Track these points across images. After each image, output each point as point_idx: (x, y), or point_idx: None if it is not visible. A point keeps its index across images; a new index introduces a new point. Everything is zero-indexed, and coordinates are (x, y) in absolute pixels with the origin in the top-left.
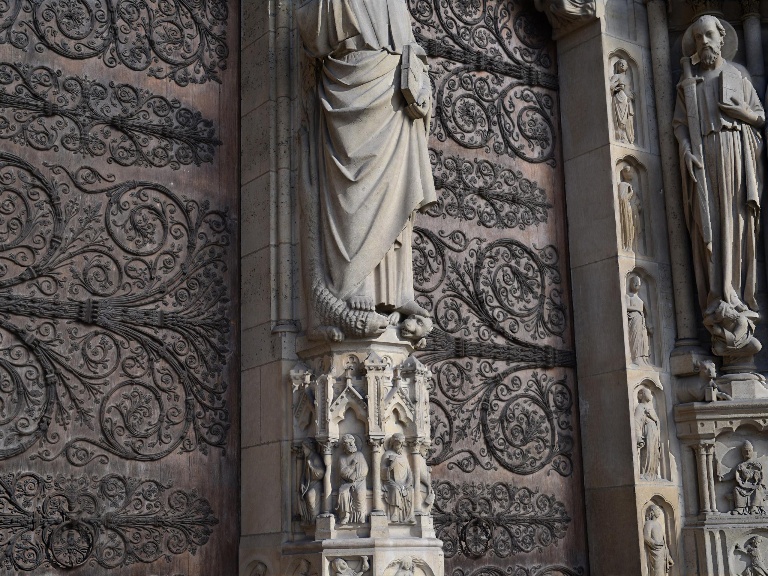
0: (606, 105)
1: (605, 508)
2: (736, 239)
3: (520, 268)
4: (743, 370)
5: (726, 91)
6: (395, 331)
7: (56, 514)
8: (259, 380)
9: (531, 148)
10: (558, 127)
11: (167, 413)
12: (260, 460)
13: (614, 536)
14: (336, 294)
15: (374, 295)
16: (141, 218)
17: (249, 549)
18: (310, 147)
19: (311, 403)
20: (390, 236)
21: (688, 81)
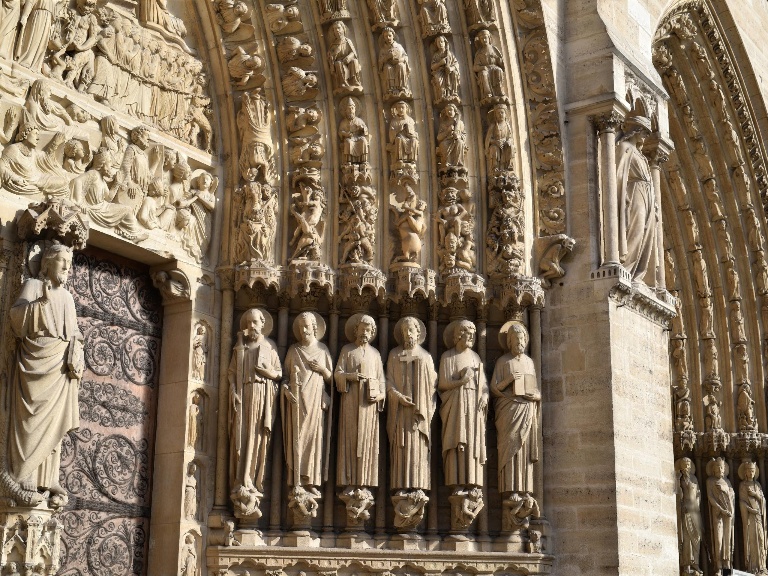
0: (189, 356)
1: None
2: (255, 449)
3: (123, 453)
4: (250, 528)
5: (260, 358)
6: (46, 503)
7: None
8: None
9: (139, 375)
10: (158, 362)
11: None
12: None
13: None
14: (15, 479)
15: (37, 481)
16: None
17: None
18: (8, 388)
19: None
20: (50, 447)
21: (240, 347)
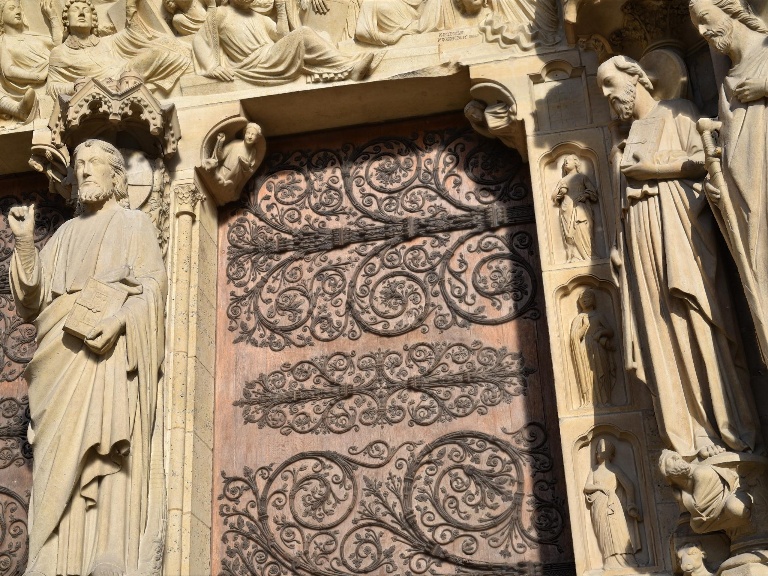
0: (536, 224)
1: None
2: (678, 351)
3: (480, 465)
4: (744, 549)
5: (629, 148)
6: None
7: None
8: None
9: (496, 306)
10: None
11: None
12: None
13: None
14: None
15: (56, 567)
16: None
17: None
18: None
19: None
20: (65, 495)
21: (611, 152)
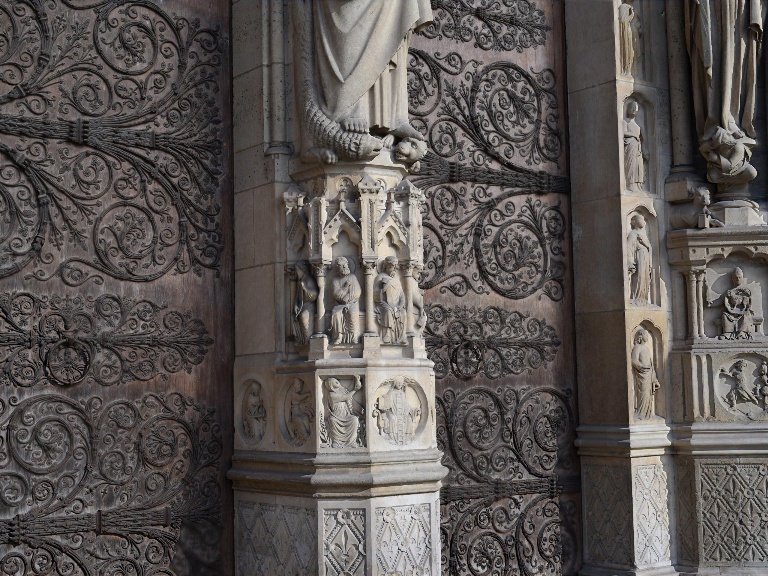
0: None
1: (595, 332)
2: (737, 64)
3: (516, 92)
4: (737, 197)
5: None
6: (389, 154)
7: (52, 333)
8: (252, 202)
9: None
10: None
11: (160, 235)
12: (254, 282)
13: (602, 359)
14: (330, 116)
15: (368, 117)
16: (130, 36)
17: (244, 368)
18: None
19: (304, 225)
20: (385, 56)
21: None
